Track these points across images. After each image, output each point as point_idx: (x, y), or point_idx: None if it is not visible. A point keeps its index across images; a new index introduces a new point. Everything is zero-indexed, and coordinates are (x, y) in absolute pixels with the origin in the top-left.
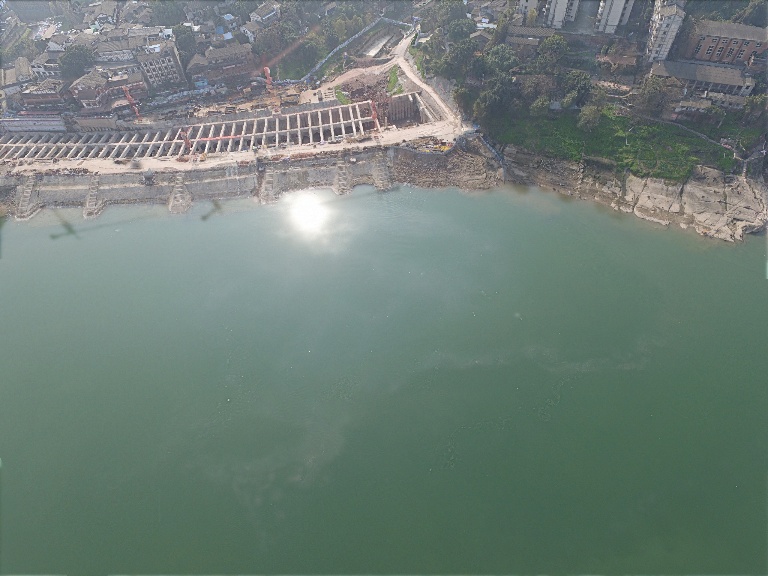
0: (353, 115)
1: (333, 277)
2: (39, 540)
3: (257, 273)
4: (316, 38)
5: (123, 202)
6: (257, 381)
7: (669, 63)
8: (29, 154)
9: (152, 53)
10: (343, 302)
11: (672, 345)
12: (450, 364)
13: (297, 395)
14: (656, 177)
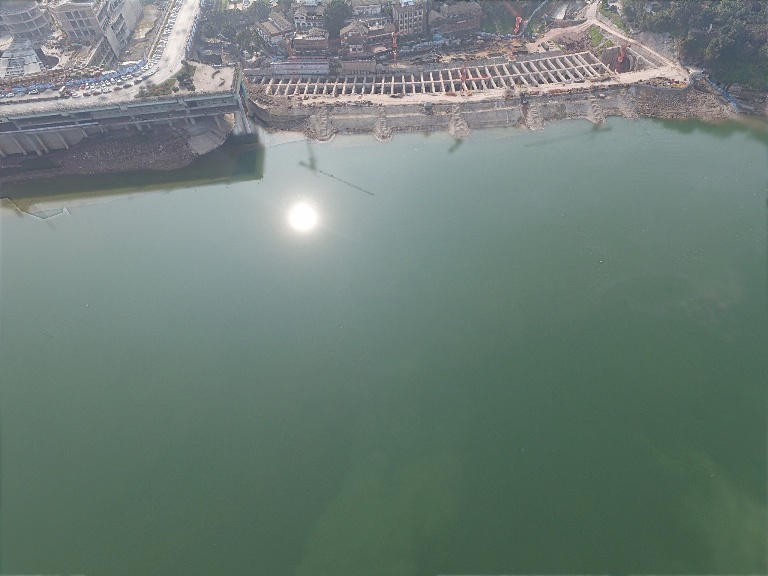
0: None
1: (630, 180)
2: (505, 352)
3: (562, 178)
4: None
5: (408, 129)
6: (614, 250)
7: None
8: (306, 91)
9: (408, 6)
10: (651, 197)
11: None
12: (766, 238)
13: (657, 257)
14: None
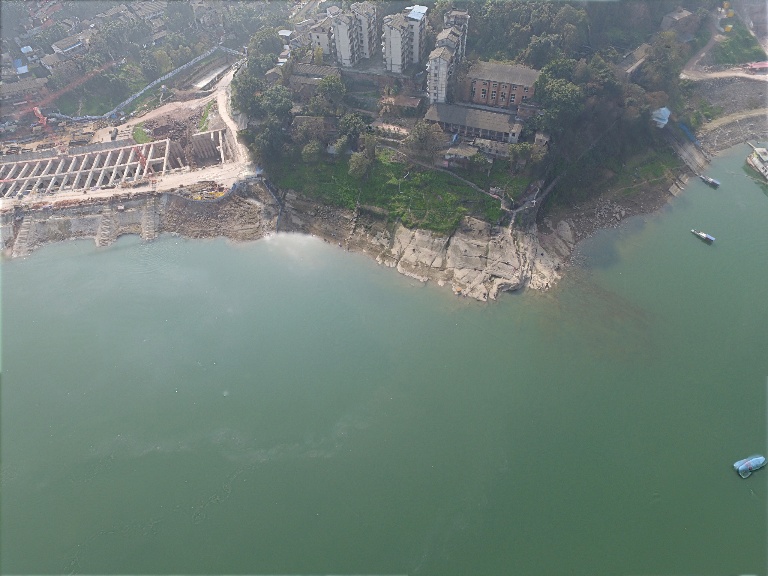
0: None
1: (48, 345)
2: None
3: None
4: (133, 70)
5: None
6: None
7: (442, 107)
8: None
9: None
10: (45, 375)
11: (372, 427)
12: (130, 451)
13: None
14: (424, 228)
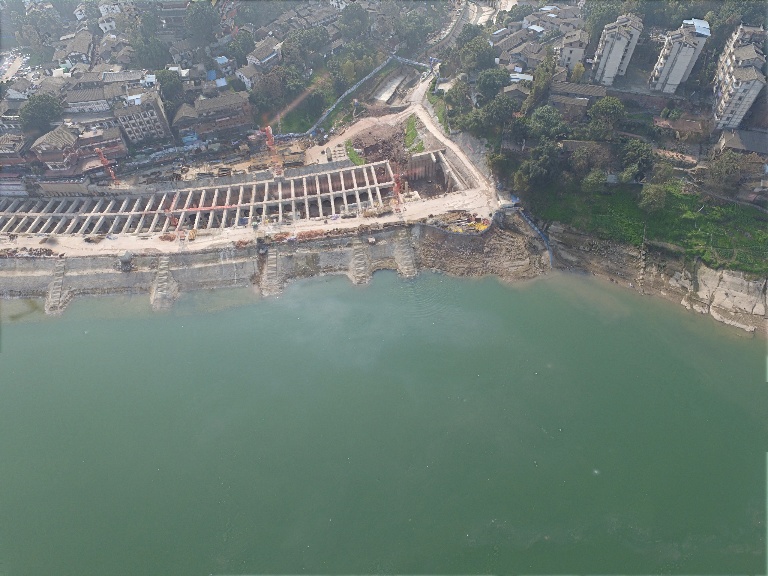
0: (367, 176)
1: (355, 404)
2: None
3: (260, 397)
4: (322, 82)
5: (94, 292)
6: (264, 570)
7: (745, 134)
8: None
9: (131, 106)
10: (370, 443)
11: None
12: (512, 540)
13: None
14: (733, 269)
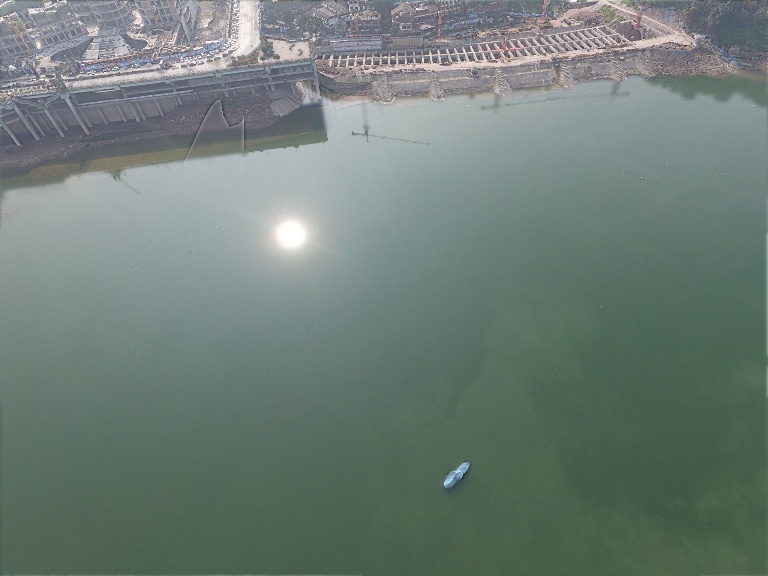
0: None
1: (655, 121)
2: (574, 243)
3: (598, 122)
4: None
5: (458, 90)
6: (651, 170)
7: None
8: None
9: None
10: (675, 132)
11: None
12: None
13: (687, 173)
14: None
